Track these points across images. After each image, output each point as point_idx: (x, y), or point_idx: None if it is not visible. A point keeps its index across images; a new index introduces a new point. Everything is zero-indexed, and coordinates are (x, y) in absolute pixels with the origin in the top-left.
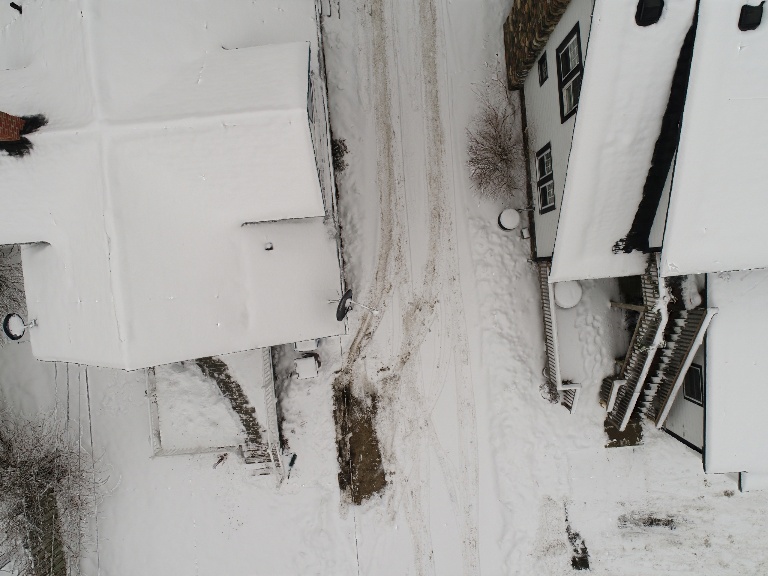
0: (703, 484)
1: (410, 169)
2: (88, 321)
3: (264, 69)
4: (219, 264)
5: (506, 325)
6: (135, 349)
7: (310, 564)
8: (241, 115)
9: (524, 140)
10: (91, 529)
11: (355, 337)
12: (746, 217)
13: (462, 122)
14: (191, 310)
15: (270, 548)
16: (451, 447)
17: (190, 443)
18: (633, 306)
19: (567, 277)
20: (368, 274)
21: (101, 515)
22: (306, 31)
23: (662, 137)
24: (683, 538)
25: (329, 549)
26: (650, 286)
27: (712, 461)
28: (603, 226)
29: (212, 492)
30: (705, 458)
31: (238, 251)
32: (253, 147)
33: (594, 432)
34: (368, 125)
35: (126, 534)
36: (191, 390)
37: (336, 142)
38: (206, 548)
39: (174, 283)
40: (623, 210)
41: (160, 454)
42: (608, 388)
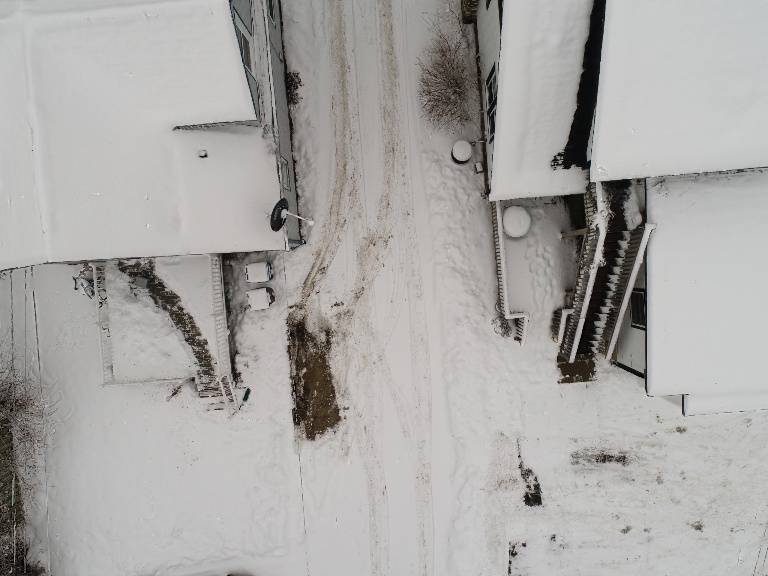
0: (655, 420)
1: (364, 103)
2: (16, 219)
3: None
4: (149, 166)
5: (459, 259)
6: (58, 241)
7: (264, 499)
8: (162, 5)
9: (478, 74)
10: (48, 464)
11: (309, 272)
12: (673, 117)
13: (416, 55)
14: (118, 208)
15: (225, 483)
16: (404, 382)
17: (142, 374)
18: (578, 231)
19: (507, 194)
20: (322, 208)
21: (57, 450)
22: None
23: (591, 38)
24: (635, 475)
25: (282, 484)
26: (591, 204)
27: (653, 382)
28: (539, 138)
29: (167, 427)
30: (647, 380)
31: (170, 155)
32: (177, 41)
33: (547, 367)
34: (323, 59)
35: (82, 469)
36: (143, 321)
37: (289, 74)
38: (161, 483)
39: (100, 180)
40: (558, 120)
41: (111, 383)
42: (558, 320)
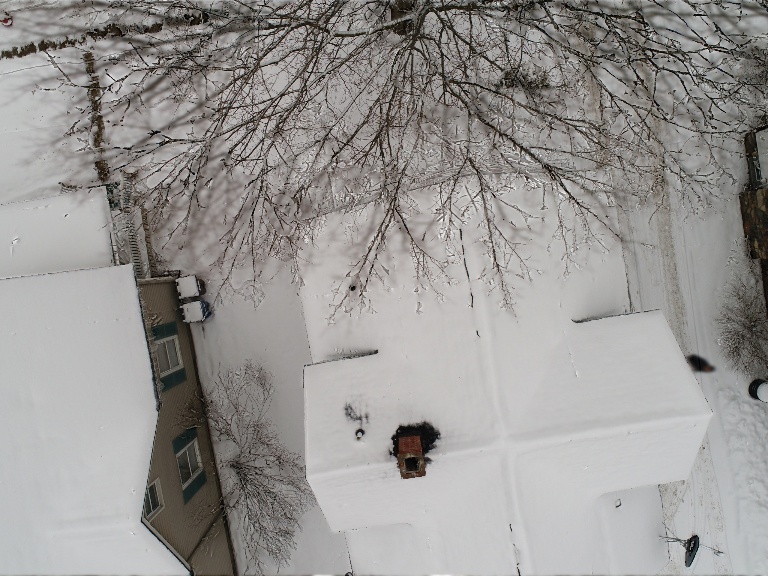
0: None
1: None
2: None
3: (639, 355)
4: (590, 539)
5: (763, 493)
6: None
7: None
8: (648, 424)
9: (767, 307)
10: None
11: None
12: None
13: (705, 295)
14: None
15: None
16: None
17: None
18: None
19: None
20: None
21: None
22: (619, 272)
23: None
24: None
25: None
26: None
27: None
28: None
29: None
30: None
31: (600, 519)
32: (648, 444)
33: None
34: None
35: None
36: None
37: None
38: None
39: (566, 575)
40: None
41: None
42: None
